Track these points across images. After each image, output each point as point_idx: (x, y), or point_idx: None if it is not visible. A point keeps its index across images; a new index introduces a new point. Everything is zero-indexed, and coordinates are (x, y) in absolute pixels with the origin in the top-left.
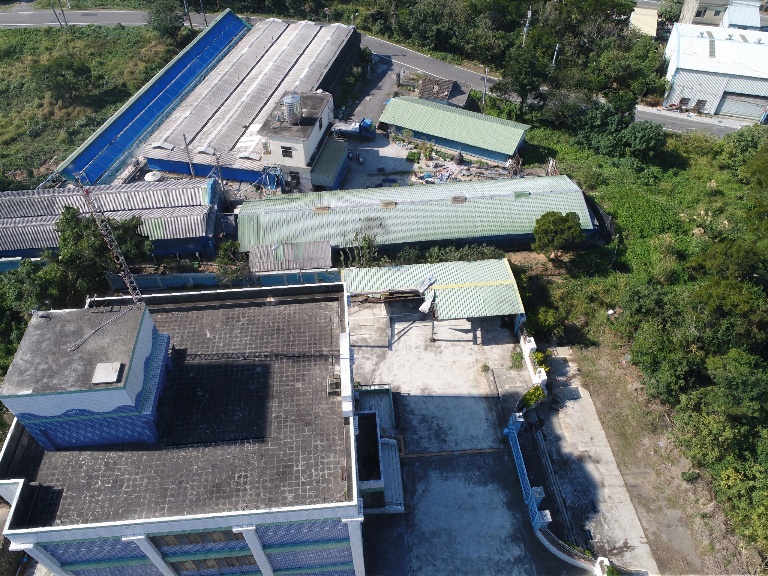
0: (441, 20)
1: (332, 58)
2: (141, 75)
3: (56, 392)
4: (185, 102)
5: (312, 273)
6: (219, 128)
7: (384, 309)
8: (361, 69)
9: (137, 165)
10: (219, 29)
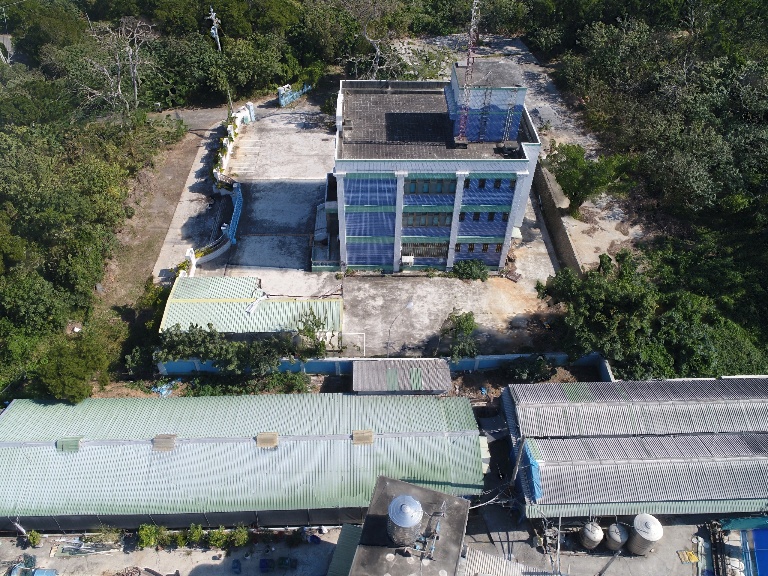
0: None
1: None
2: None
3: None
4: None
5: None
6: None
7: None
8: None
9: None
10: None
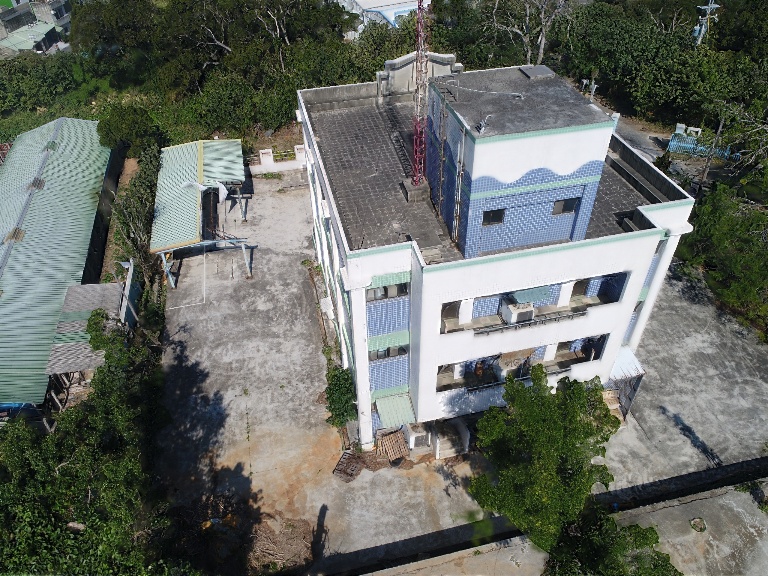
0: None
1: None
2: None
3: None
4: None
5: None
6: None
7: (193, 257)
8: None
9: None
10: None
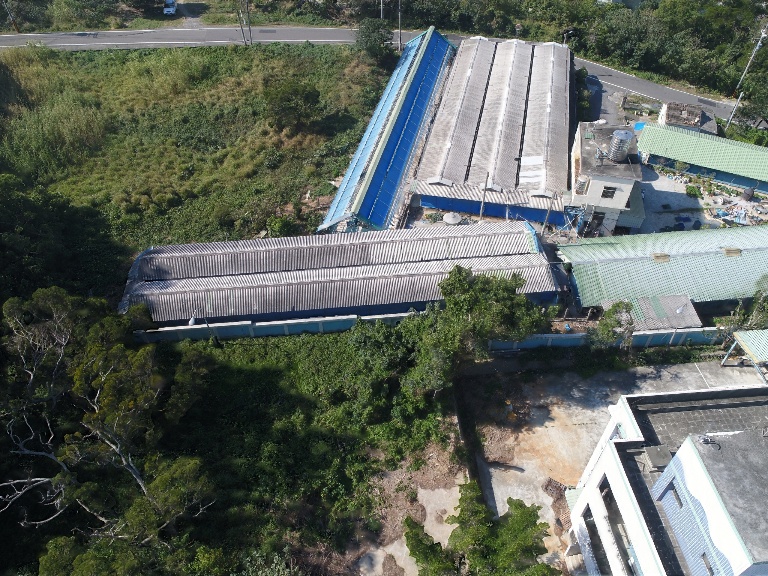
0: (648, 38)
1: (566, 81)
2: (360, 99)
3: None
4: (435, 131)
5: (682, 333)
6: (493, 161)
7: None
8: (590, 92)
9: (406, 202)
10: (431, 49)
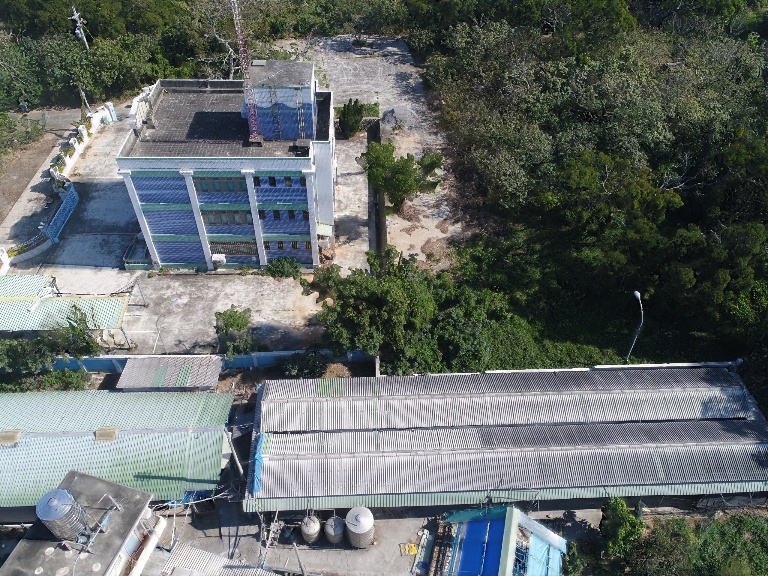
0: None
1: None
2: None
3: None
4: None
5: None
6: None
7: None
8: None
9: None
10: None
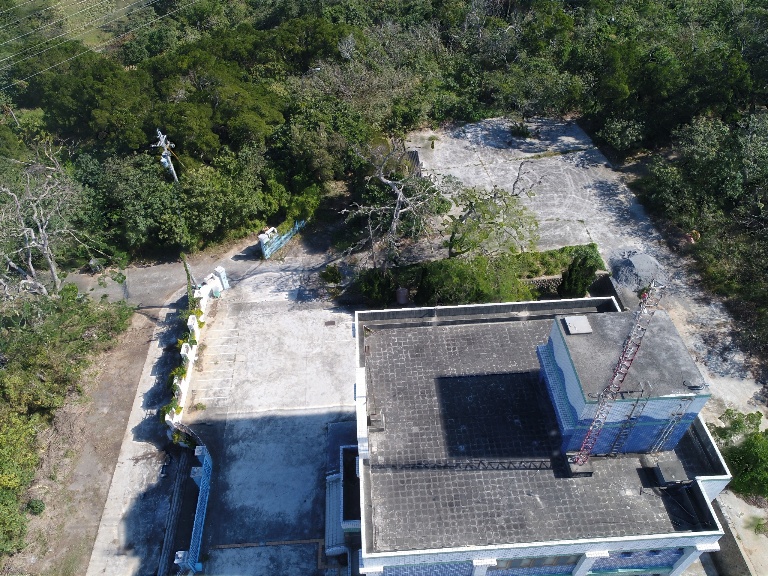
0: None
1: None
2: None
3: (615, 312)
4: None
5: None
6: None
7: None
8: None
9: None
10: None
